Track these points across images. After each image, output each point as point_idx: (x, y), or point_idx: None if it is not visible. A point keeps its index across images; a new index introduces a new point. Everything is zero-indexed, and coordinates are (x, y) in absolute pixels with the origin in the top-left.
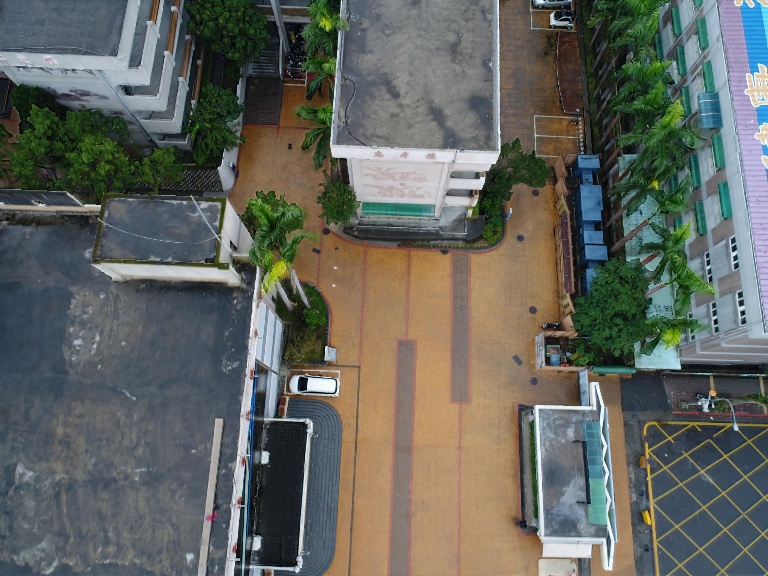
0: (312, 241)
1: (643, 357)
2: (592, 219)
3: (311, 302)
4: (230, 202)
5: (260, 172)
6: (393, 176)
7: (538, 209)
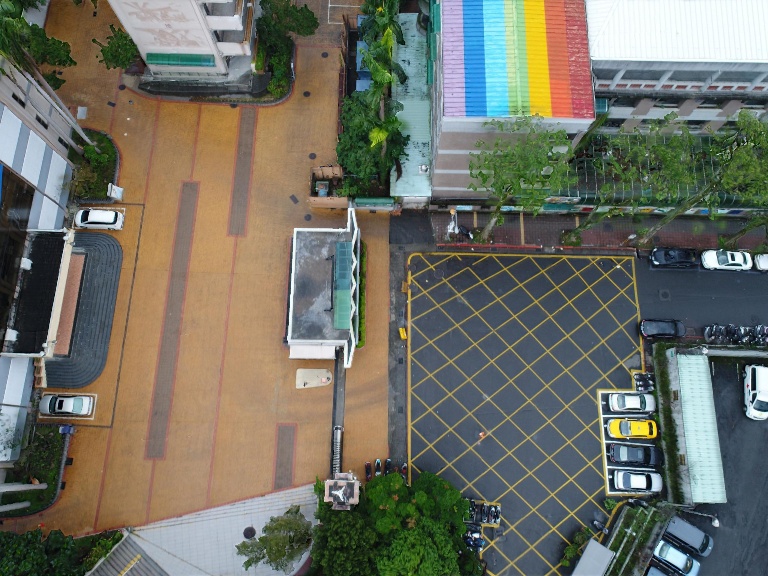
0: (108, 95)
1: (398, 186)
2: (365, 70)
3: (102, 148)
4: None
5: (64, 36)
6: (154, 14)
7: (326, 69)
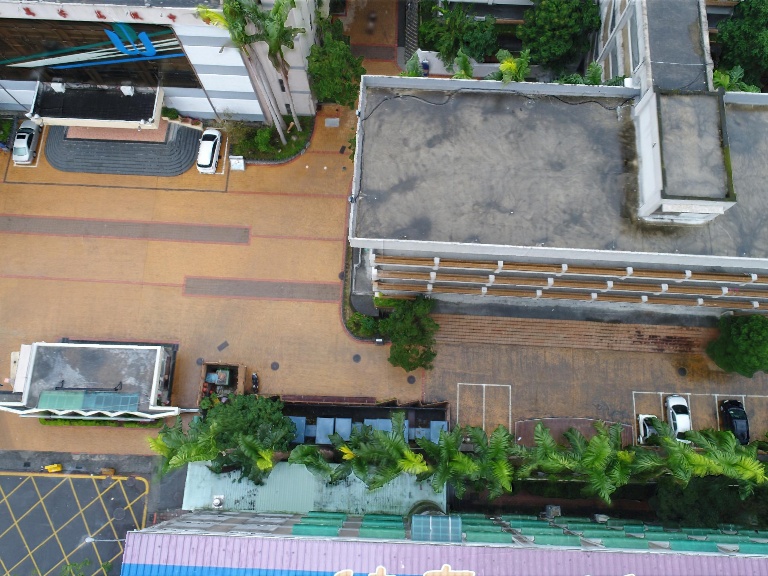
0: None
1: (200, 468)
2: None
3: (290, 145)
4: (394, 71)
5: None
6: None
7: (391, 381)
